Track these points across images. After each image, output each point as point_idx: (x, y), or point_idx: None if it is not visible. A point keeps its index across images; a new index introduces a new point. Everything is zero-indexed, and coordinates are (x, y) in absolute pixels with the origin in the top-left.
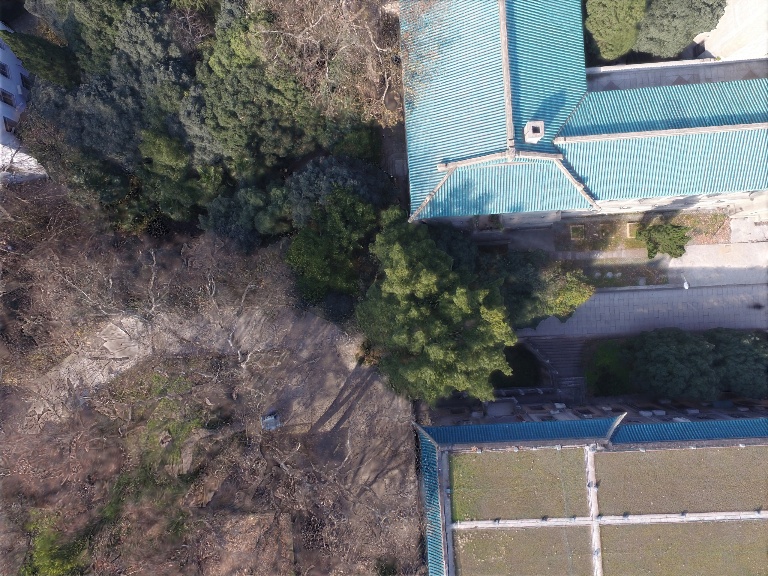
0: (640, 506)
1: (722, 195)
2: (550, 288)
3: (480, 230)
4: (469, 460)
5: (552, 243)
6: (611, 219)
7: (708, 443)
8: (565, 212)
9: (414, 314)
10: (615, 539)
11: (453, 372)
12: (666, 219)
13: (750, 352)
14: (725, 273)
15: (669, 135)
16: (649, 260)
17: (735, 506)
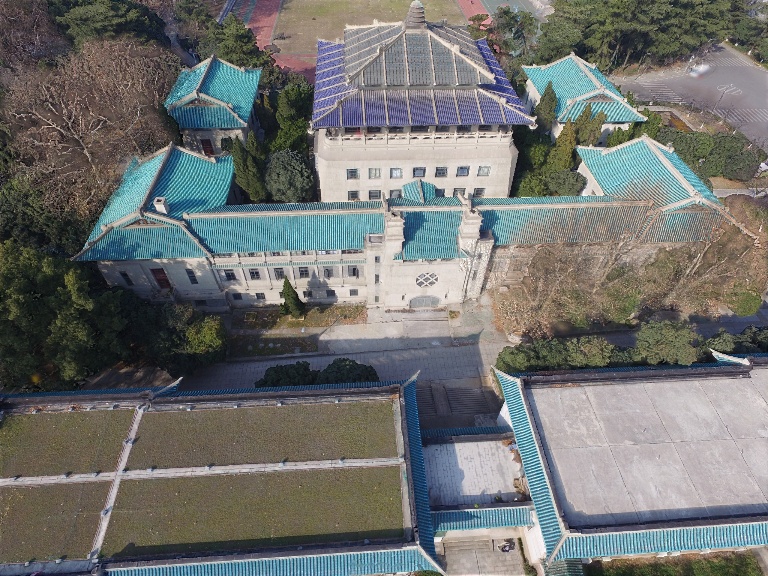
0: (169, 460)
1: (337, 278)
2: (179, 318)
3: (155, 297)
4: (21, 421)
5: (230, 324)
6: (279, 309)
7: (241, 395)
8: (238, 299)
9: (3, 269)
10: (132, 495)
11: (6, 300)
12: (321, 310)
13: (335, 365)
14: (362, 343)
15: (259, 216)
16: (304, 335)
17: (262, 458)
